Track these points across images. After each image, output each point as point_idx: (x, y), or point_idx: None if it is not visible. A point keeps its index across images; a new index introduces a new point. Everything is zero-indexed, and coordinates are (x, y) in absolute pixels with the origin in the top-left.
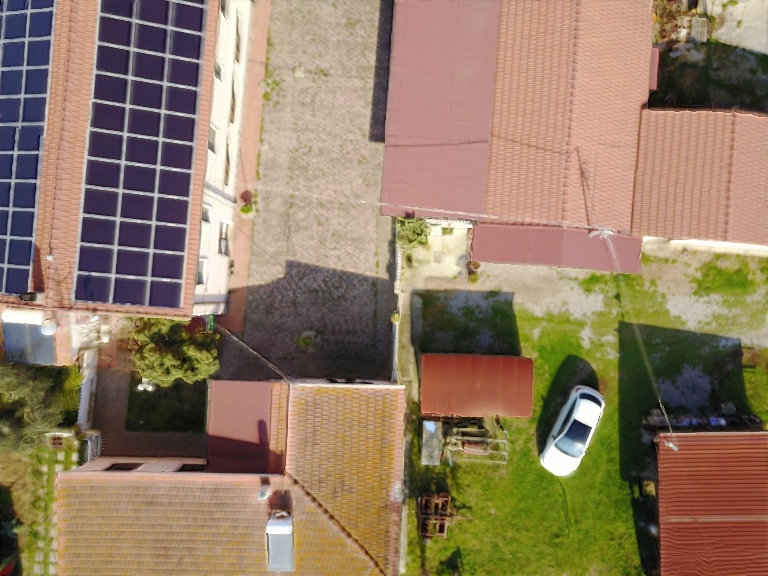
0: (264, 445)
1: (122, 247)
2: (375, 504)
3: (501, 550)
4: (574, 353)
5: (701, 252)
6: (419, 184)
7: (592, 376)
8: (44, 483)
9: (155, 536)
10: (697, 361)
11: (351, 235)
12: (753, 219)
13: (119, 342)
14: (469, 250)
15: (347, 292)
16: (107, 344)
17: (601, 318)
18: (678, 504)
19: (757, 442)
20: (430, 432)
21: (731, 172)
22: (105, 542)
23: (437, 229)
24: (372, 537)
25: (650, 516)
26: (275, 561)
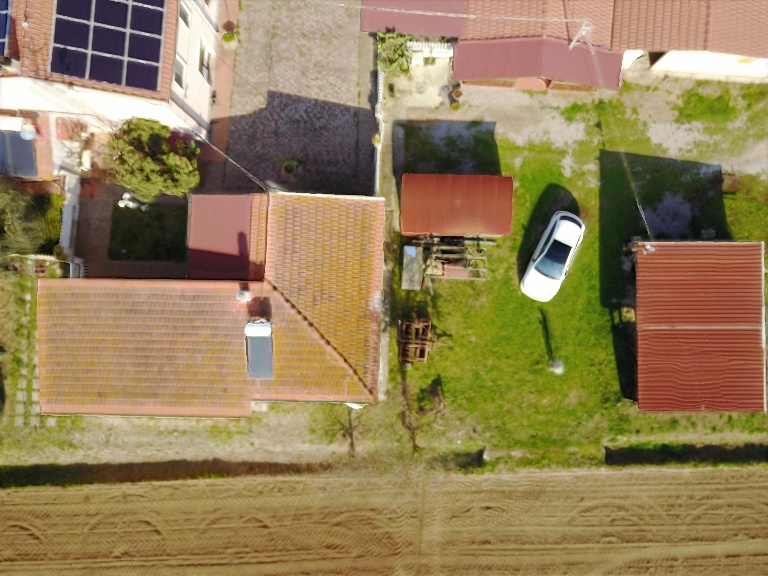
0: (244, 257)
1: (98, 24)
2: (354, 313)
3: (481, 377)
4: (555, 182)
5: (682, 79)
6: (399, 0)
7: (573, 205)
8: (26, 311)
9: (135, 344)
10: (678, 188)
11: (333, 65)
12: (733, 29)
13: (101, 172)
14: (451, 80)
15: (329, 123)
16: None
17: (582, 147)
18: (656, 312)
19: (735, 253)
20: (411, 257)
21: None
22: (85, 350)
23: (418, 55)
24: (351, 346)
25: (629, 338)
26: (254, 368)
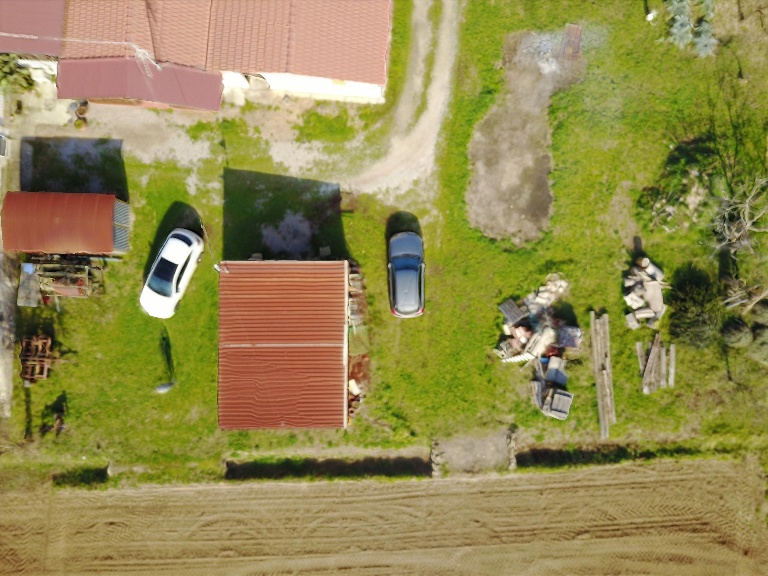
0: None
1: None
2: None
3: (106, 394)
4: (180, 199)
5: (302, 98)
6: None
7: (197, 222)
8: None
9: None
10: (298, 206)
11: None
12: (316, 52)
13: None
14: None
15: None
16: None
17: (207, 164)
18: (237, 330)
19: (321, 271)
20: (27, 274)
21: (292, 4)
22: None
23: (37, 73)
24: None
25: None
26: None
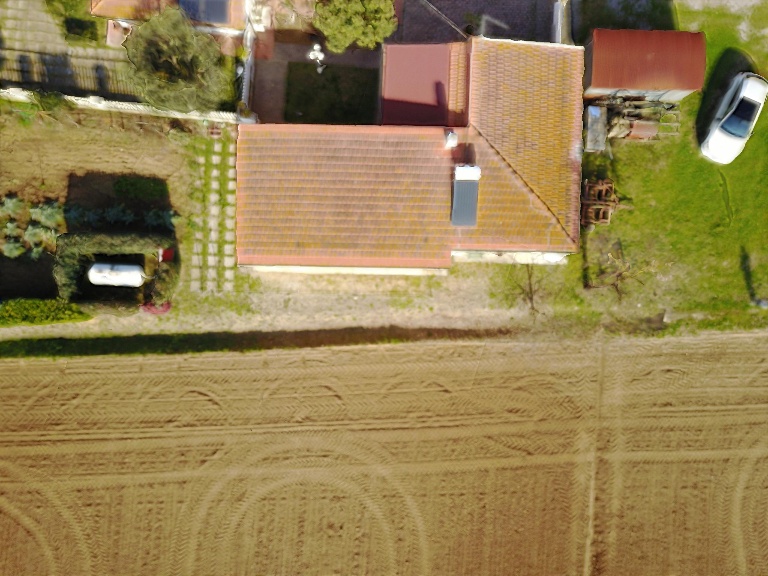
0: (442, 107)
1: None
2: (556, 162)
3: (661, 241)
4: (735, 45)
5: None
6: None
7: (752, 68)
8: (201, 175)
9: (336, 193)
10: None
11: None
12: None
13: (277, 33)
14: None
15: None
16: (265, 33)
17: (762, 10)
18: None
19: None
20: (595, 117)
21: None
22: (285, 199)
23: None
24: (553, 194)
25: None
26: (458, 215)
